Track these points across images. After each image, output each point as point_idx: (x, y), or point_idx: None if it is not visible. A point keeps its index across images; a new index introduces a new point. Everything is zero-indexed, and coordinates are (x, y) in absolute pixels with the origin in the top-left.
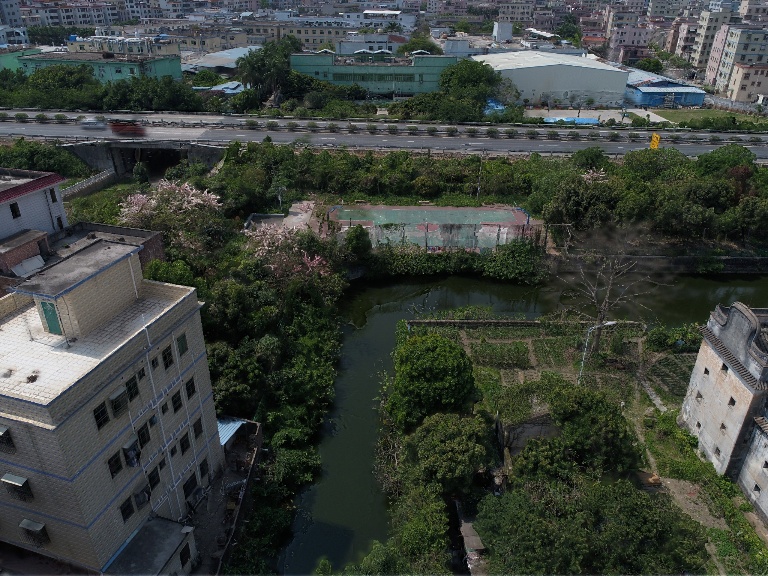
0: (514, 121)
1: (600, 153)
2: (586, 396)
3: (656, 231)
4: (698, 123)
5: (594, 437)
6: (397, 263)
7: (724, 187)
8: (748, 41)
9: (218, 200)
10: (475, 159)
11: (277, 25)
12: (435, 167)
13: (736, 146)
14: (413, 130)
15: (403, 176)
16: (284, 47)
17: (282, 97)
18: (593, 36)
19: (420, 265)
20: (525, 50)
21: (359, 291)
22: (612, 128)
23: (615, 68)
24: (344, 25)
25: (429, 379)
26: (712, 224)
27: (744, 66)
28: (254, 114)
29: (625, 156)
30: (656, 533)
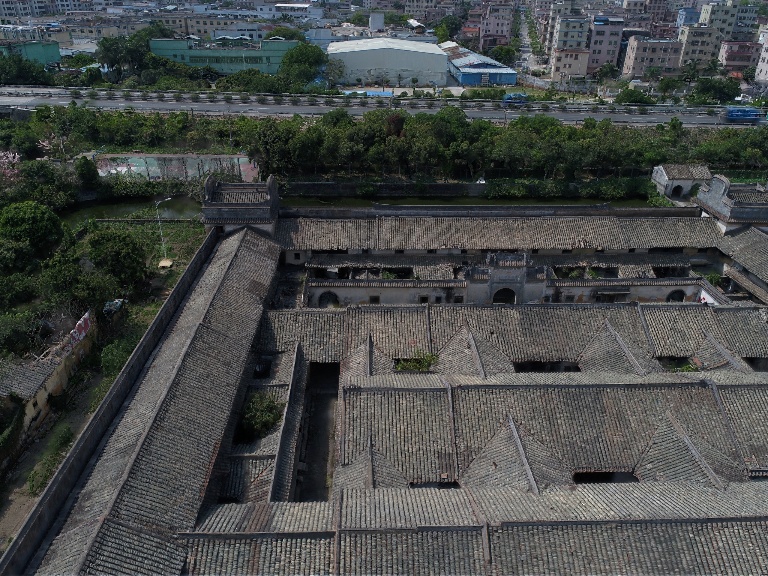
0: (312, 93)
1: (343, 113)
2: (108, 233)
3: (345, 167)
4: (468, 94)
5: (103, 255)
6: (117, 186)
7: (378, 130)
8: (567, 29)
9: (4, 146)
10: (241, 118)
11: (185, 17)
12: (212, 126)
13: (451, 107)
14: (212, 98)
15: (176, 131)
16: (148, 33)
17: (126, 75)
18: (472, 27)
19: (138, 188)
20: (379, 37)
21: (85, 207)
22: (394, 98)
23: (441, 52)
24: (253, 17)
25: (13, 225)
26: (361, 156)
27: (558, 50)
28: (90, 87)
29: (363, 115)
30: (65, 282)
